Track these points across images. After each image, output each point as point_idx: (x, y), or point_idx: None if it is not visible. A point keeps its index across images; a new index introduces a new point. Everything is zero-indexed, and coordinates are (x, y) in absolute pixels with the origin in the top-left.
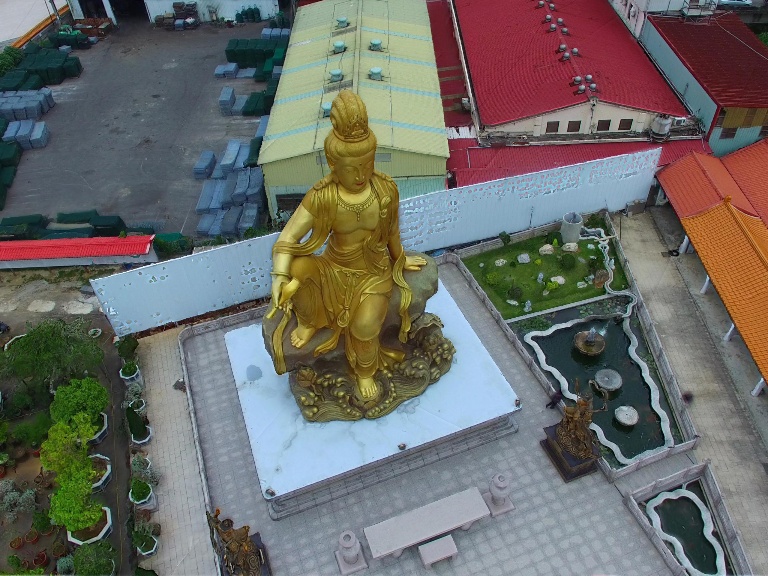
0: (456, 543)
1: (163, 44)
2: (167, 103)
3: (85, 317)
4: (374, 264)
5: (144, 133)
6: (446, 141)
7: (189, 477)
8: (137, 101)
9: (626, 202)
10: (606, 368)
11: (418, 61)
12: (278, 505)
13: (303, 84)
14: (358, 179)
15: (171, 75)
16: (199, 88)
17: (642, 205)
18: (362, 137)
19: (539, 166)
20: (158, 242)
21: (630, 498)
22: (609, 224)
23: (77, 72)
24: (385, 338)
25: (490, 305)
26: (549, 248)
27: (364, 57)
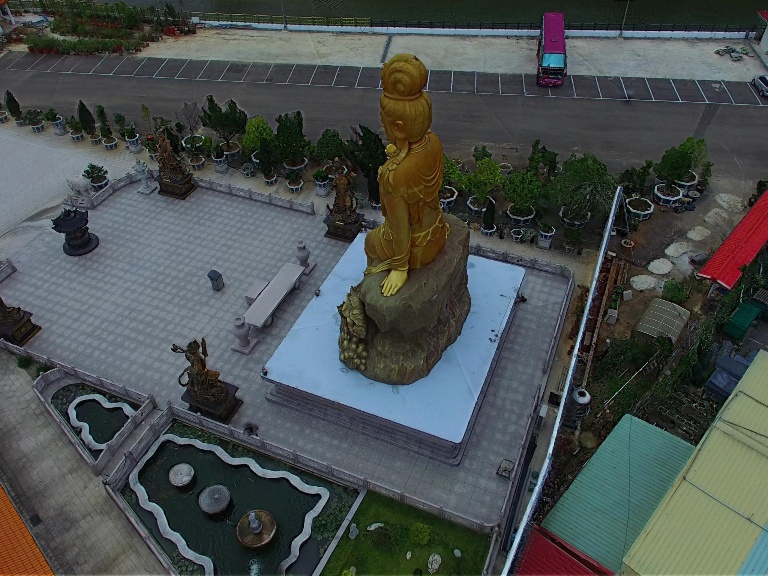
0: None
1: None
2: None
3: None
4: None
5: None
6: None
7: None
8: None
9: None
10: None
11: None
12: None
13: None
14: None
15: None
16: None
17: None
18: None
19: None
20: None
21: None
22: None
23: None
24: None
25: None
26: None
27: None
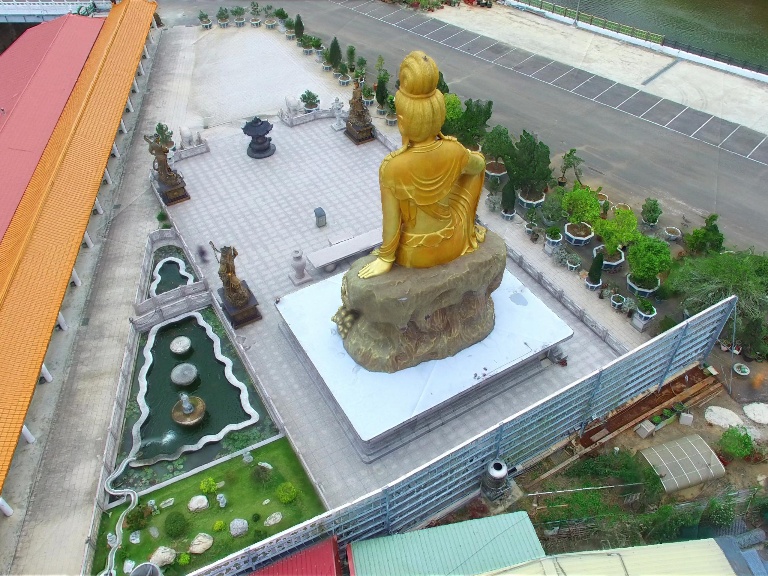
0: None
1: None
2: None
3: None
4: None
5: None
6: None
7: None
8: None
9: None
10: None
11: None
12: None
13: None
14: None
15: None
16: None
17: None
18: None
19: None
20: None
21: (206, 278)
22: None
23: None
24: None
25: None
26: (198, 539)
27: None
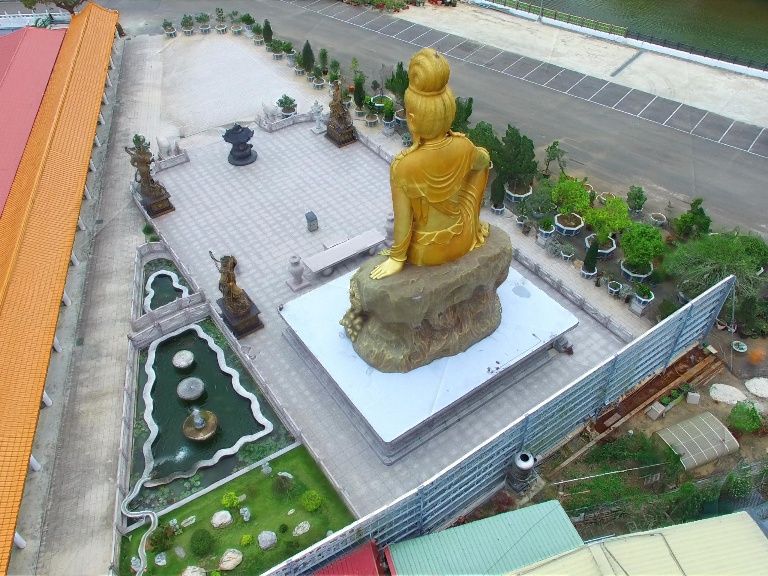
0: None
1: None
2: None
3: None
4: None
5: None
6: None
7: None
8: None
9: None
10: None
11: None
12: None
13: None
14: None
15: None
16: None
17: None
18: None
19: None
20: None
21: None
22: None
23: None
24: None
25: None
26: (228, 555)
27: None
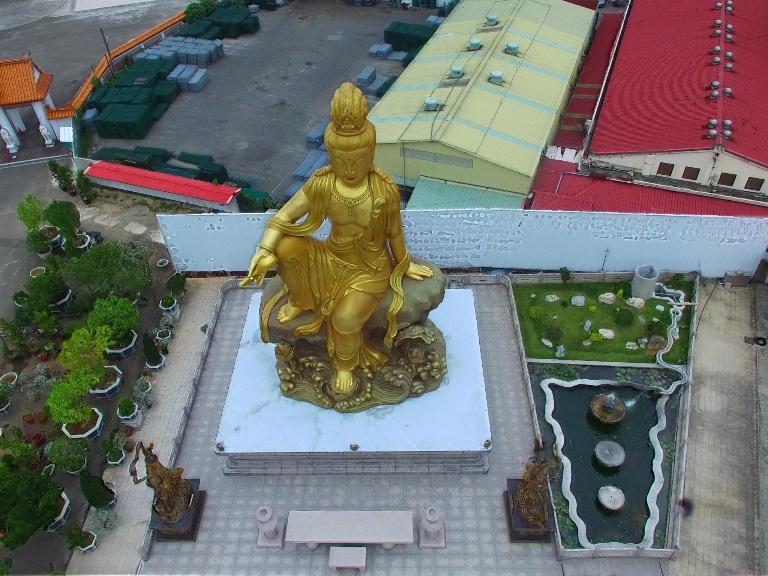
0: (372, 558)
1: (337, 16)
2: (315, 72)
3: (151, 246)
4: (365, 262)
5: (283, 95)
6: (537, 159)
7: (177, 411)
8: (291, 65)
9: (726, 270)
10: (613, 441)
11: (551, 72)
12: (232, 461)
13: (425, 75)
14: (347, 173)
15: (331, 46)
16: (349, 63)
17: (745, 278)
18: (353, 132)
19: (633, 208)
20: (244, 196)
21: None
22: (695, 289)
23: (253, 30)
24: (375, 338)
25: (519, 338)
26: (609, 297)
27: (494, 59)
